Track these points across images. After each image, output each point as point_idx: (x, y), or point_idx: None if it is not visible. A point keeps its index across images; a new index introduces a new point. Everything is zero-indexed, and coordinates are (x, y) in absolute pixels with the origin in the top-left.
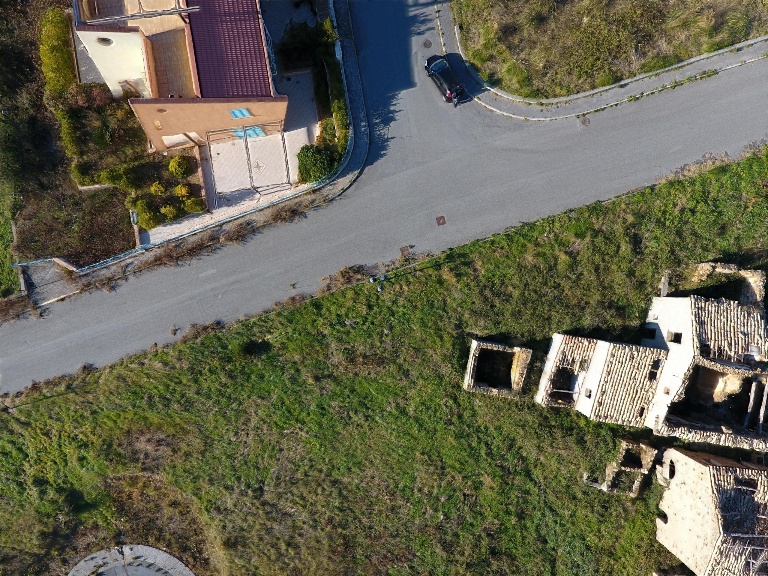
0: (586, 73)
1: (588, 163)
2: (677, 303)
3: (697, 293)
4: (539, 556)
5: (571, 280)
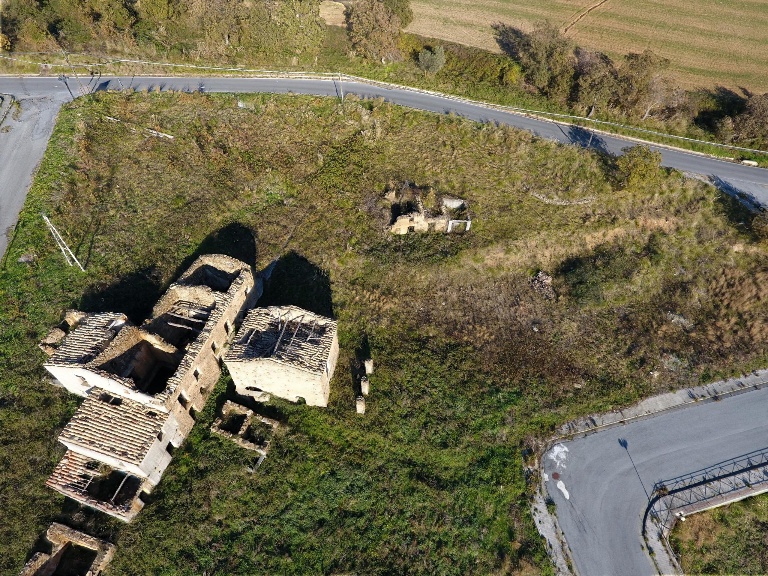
0: None
1: None
2: None
3: None
4: (336, 530)
5: (3, 470)
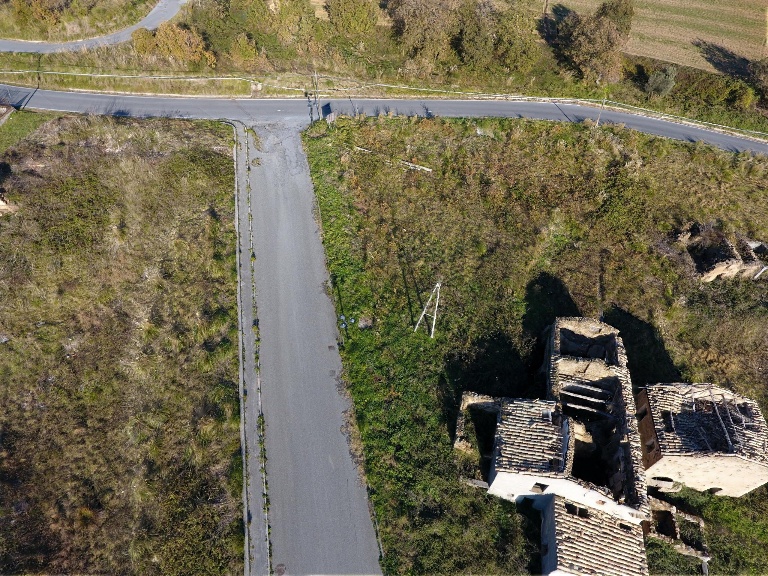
0: (222, 569)
1: (332, 571)
2: (501, 481)
3: (483, 451)
4: None
5: None
